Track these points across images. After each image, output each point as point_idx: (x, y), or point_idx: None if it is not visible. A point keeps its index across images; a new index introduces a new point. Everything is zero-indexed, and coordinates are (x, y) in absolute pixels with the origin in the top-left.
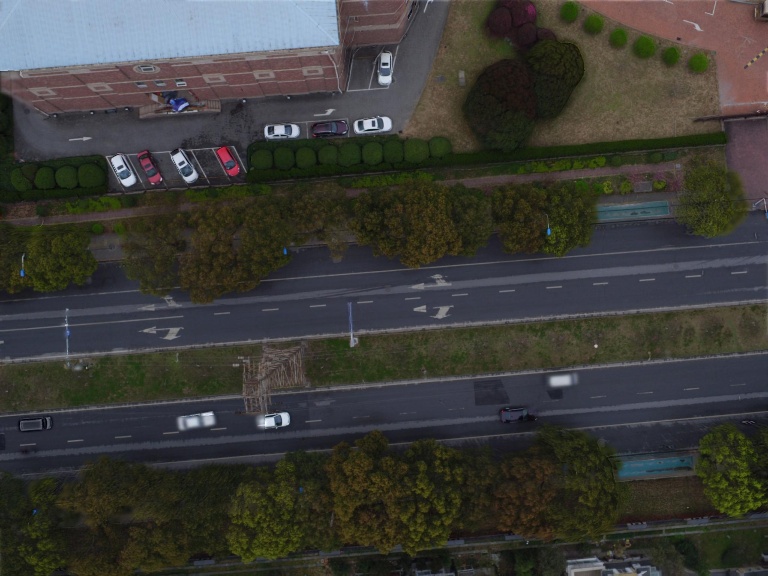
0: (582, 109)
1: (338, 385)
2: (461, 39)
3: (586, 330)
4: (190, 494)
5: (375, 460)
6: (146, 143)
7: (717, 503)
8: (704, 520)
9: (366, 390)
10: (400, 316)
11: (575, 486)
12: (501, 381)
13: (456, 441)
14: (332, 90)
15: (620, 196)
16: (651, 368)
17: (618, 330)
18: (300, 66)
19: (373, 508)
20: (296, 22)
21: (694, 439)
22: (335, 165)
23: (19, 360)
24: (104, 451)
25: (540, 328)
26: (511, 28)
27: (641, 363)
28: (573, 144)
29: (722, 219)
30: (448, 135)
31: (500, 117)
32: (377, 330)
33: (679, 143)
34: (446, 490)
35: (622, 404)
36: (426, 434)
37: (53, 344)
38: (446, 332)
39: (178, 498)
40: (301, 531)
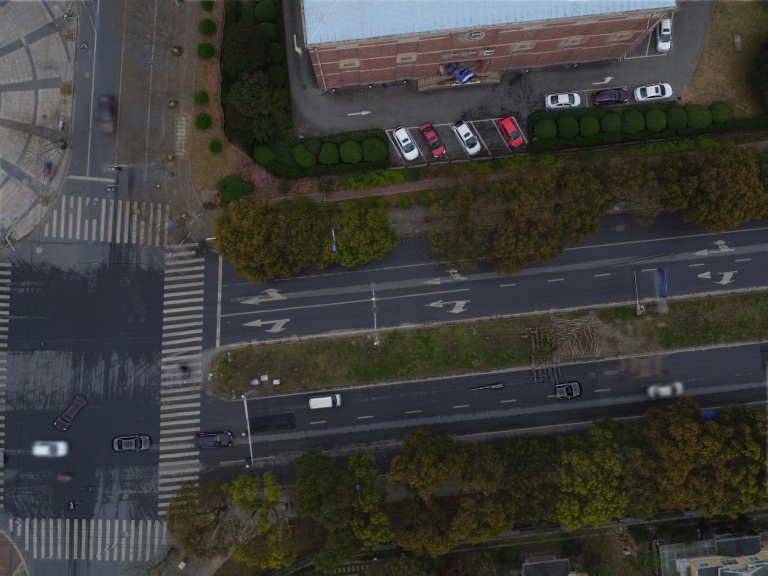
0: None
1: (623, 354)
2: (735, 4)
3: None
4: (503, 465)
5: (700, 424)
6: (425, 116)
7: None
8: None
9: (653, 358)
10: (685, 283)
11: None
12: None
13: (751, 406)
14: (618, 57)
15: None
16: None
17: None
18: (618, 30)
19: (702, 472)
20: None
21: None
22: (619, 133)
23: (306, 338)
24: (395, 427)
25: None
26: None
27: None
28: None
29: None
30: (726, 100)
31: None
32: (663, 297)
33: None
34: None
35: None
36: (723, 399)
37: (340, 321)
38: (732, 297)
39: (492, 469)
40: (628, 497)
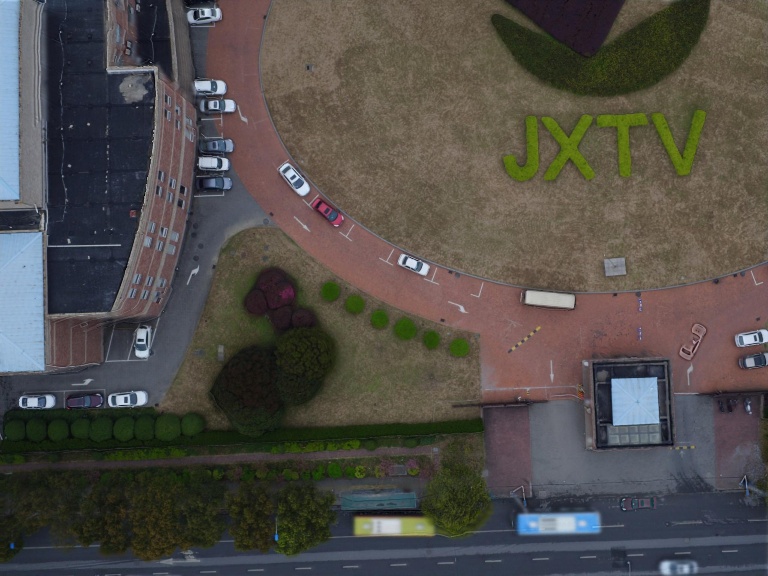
0: (340, 389)
1: None
2: (223, 313)
3: None
4: None
5: None
6: None
7: None
8: None
9: None
10: None
11: None
12: None
13: None
14: (83, 368)
15: (375, 479)
16: None
17: None
18: None
19: None
20: (1, 348)
21: None
22: (86, 439)
23: None
24: None
25: None
26: (267, 309)
27: None
28: (329, 425)
29: (476, 508)
30: (204, 410)
31: (238, 412)
32: None
33: (433, 431)
34: None
35: None
36: None
37: None
38: None
39: None
40: None
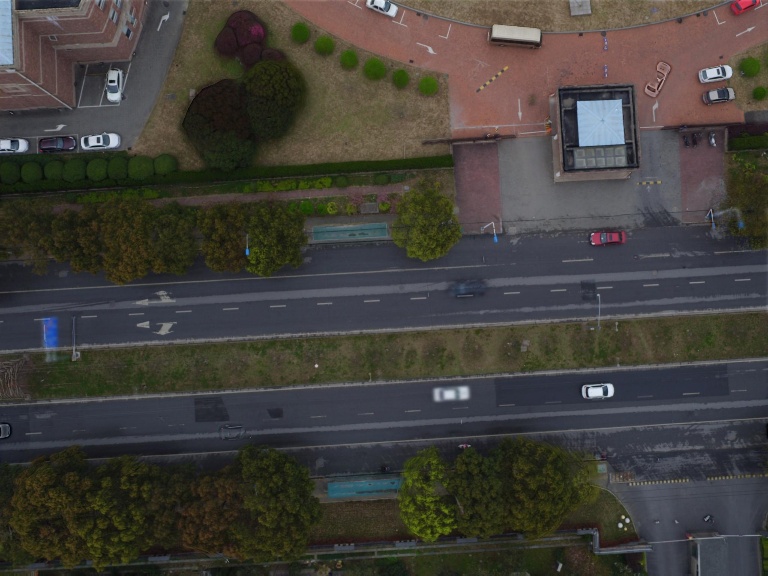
0: (311, 129)
1: (62, 398)
2: (193, 58)
3: (307, 350)
4: None
5: (59, 475)
6: None
7: (409, 527)
8: (412, 543)
9: (87, 404)
10: (123, 331)
11: (252, 506)
12: (221, 398)
13: (169, 457)
14: (55, 106)
15: (347, 217)
16: (372, 389)
17: (339, 350)
18: None
19: (53, 523)
20: None
21: (407, 461)
22: (60, 180)
23: None
24: None
25: (262, 346)
26: (237, 48)
27: (363, 384)
28: (300, 164)
29: (447, 242)
30: (176, 153)
31: (209, 137)
32: (100, 345)
33: (404, 165)
34: (129, 507)
35: (342, 424)
36: (137, 450)
37: None
38: (168, 348)
39: None
40: None
